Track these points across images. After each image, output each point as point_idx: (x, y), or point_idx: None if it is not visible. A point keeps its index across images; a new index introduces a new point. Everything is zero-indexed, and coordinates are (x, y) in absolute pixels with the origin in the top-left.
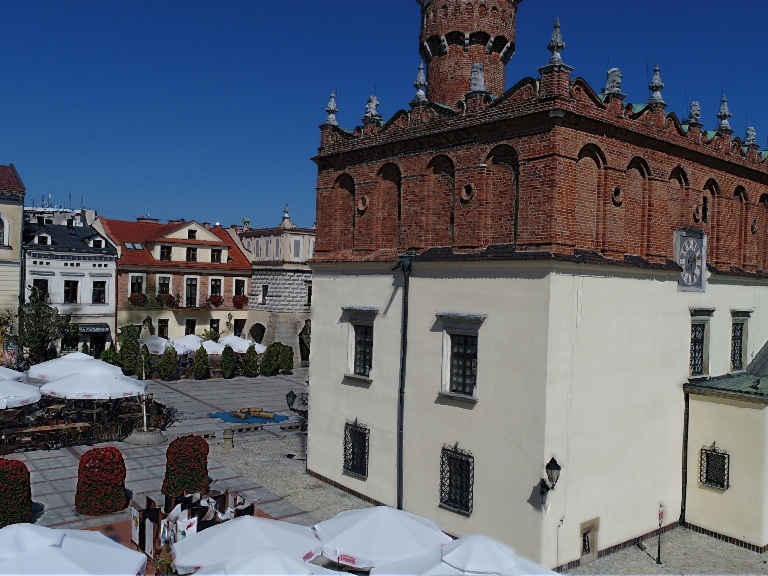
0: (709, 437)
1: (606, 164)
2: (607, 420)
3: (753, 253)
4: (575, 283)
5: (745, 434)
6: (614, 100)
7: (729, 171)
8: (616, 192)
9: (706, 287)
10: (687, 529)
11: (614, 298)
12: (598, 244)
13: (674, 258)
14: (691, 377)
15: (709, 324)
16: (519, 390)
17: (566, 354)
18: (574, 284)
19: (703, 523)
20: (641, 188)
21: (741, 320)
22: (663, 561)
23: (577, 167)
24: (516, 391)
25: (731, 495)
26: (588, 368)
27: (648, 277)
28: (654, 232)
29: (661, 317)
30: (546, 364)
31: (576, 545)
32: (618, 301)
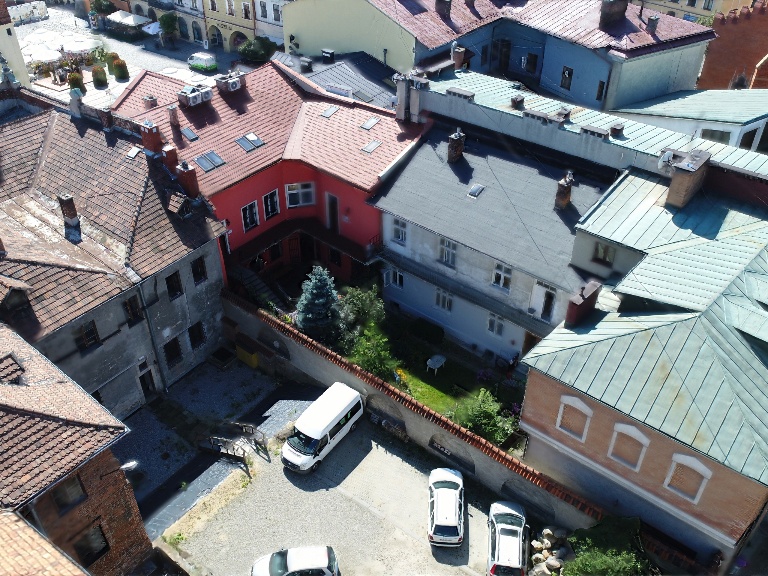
0: None
1: None
2: None
3: None
4: None
5: None
6: None
7: None
8: None
9: None
10: None
11: None
12: None
13: None
14: None
15: None
16: None
17: None
18: None
19: None
20: None
21: None
22: None
23: None
24: None
25: None
26: None
27: None
28: None
29: None
30: None
31: None
32: None
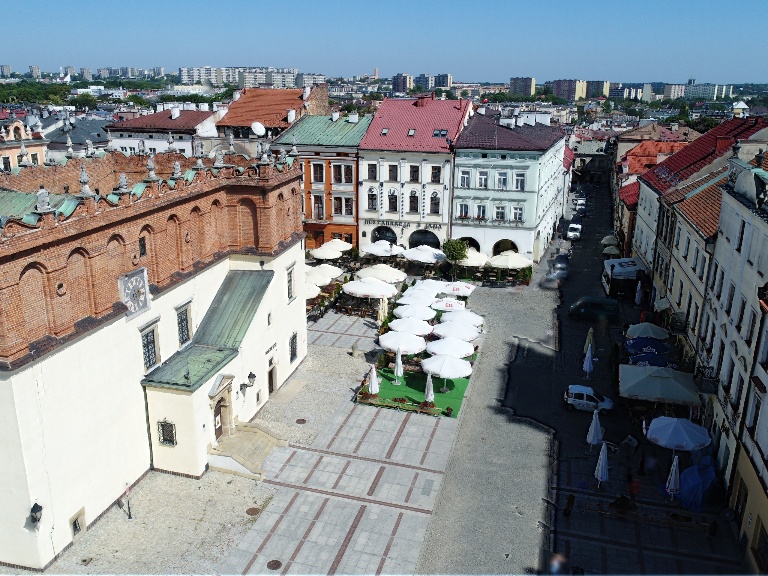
0: (162, 414)
1: (47, 270)
2: (80, 443)
3: (189, 256)
4: (35, 371)
5: (182, 411)
6: (46, 217)
7: (160, 210)
8: (60, 286)
9: (151, 305)
10: (155, 472)
11: (71, 361)
12: (51, 329)
13: (121, 299)
14: (146, 373)
15: (157, 328)
16: (2, 456)
17: (36, 423)
18: (34, 372)
19: (165, 467)
20: (83, 265)
21: (185, 308)
22: (134, 514)
23: (21, 282)
24: (0, 457)
25: (179, 448)
26: (57, 420)
27: (99, 329)
28: (99, 295)
29: (115, 349)
30: (20, 439)
31: (68, 534)
32: (75, 361)
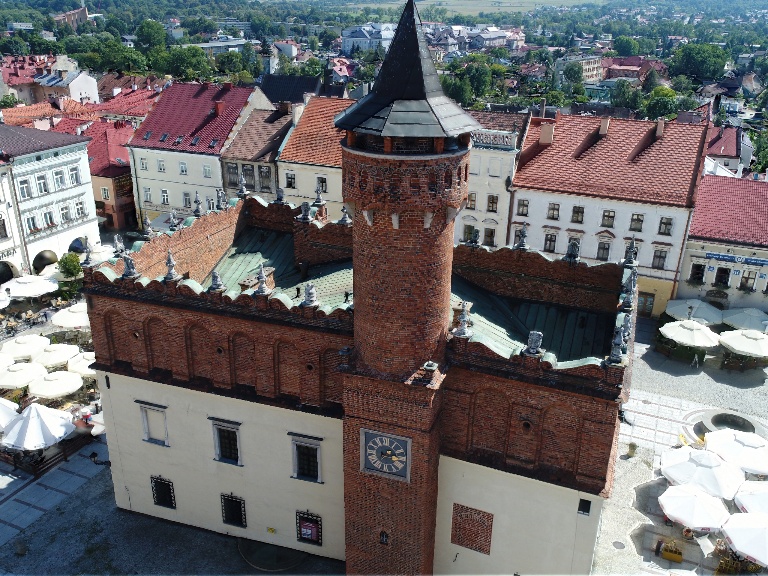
0: None
1: None
2: None
3: None
4: None
5: None
6: None
7: None
8: None
9: None
10: None
11: None
12: None
13: None
14: None
15: None
16: None
17: None
18: None
19: None
20: None
21: None
22: None
23: None
24: None
25: None
26: None
27: None
28: None
29: None
30: None
31: None
32: None
